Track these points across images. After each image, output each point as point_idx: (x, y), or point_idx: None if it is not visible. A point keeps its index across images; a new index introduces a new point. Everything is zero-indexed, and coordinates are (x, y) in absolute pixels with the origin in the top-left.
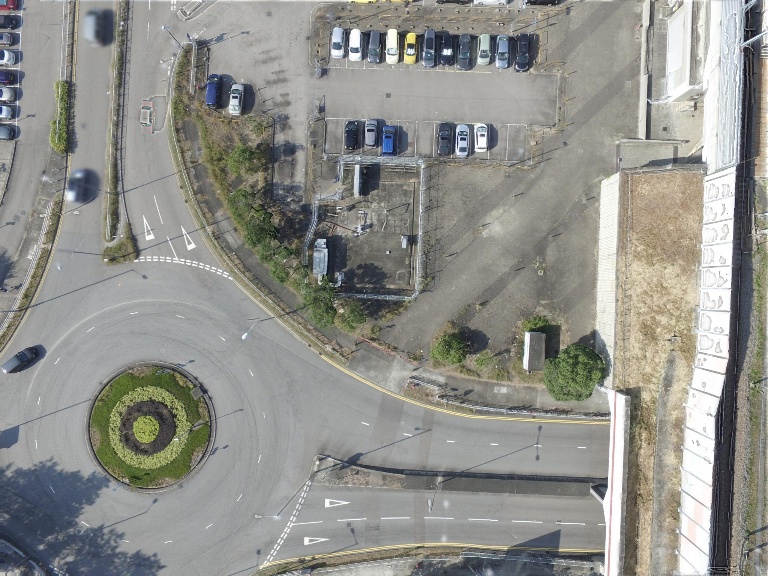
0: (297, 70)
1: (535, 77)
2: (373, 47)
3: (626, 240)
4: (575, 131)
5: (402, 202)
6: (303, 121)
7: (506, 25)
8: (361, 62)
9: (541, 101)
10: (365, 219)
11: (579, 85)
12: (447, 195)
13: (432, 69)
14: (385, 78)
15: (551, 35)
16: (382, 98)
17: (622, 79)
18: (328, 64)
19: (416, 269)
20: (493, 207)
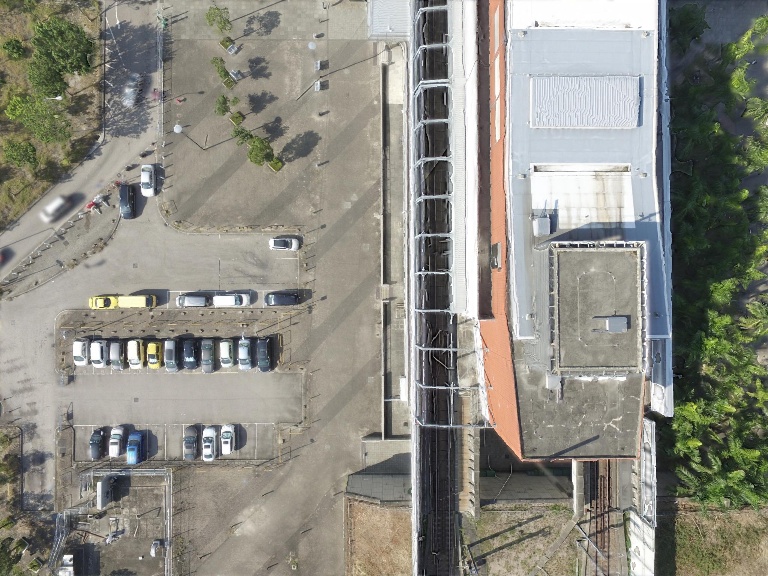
0: (43, 378)
1: (280, 376)
2: (116, 357)
3: (351, 563)
4: (321, 428)
5: (153, 506)
6: (51, 429)
7: (250, 326)
8: (107, 368)
9: (287, 399)
10: (117, 525)
11: (323, 382)
12: (198, 497)
13: (179, 372)
14: (132, 382)
15: (294, 334)
16: (130, 403)
17: (365, 375)
18: (74, 371)
19: (170, 572)
20: (244, 506)
